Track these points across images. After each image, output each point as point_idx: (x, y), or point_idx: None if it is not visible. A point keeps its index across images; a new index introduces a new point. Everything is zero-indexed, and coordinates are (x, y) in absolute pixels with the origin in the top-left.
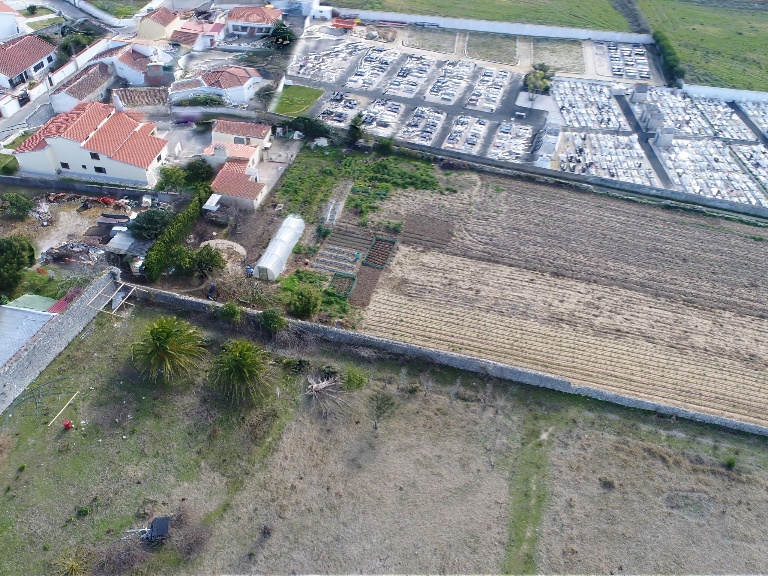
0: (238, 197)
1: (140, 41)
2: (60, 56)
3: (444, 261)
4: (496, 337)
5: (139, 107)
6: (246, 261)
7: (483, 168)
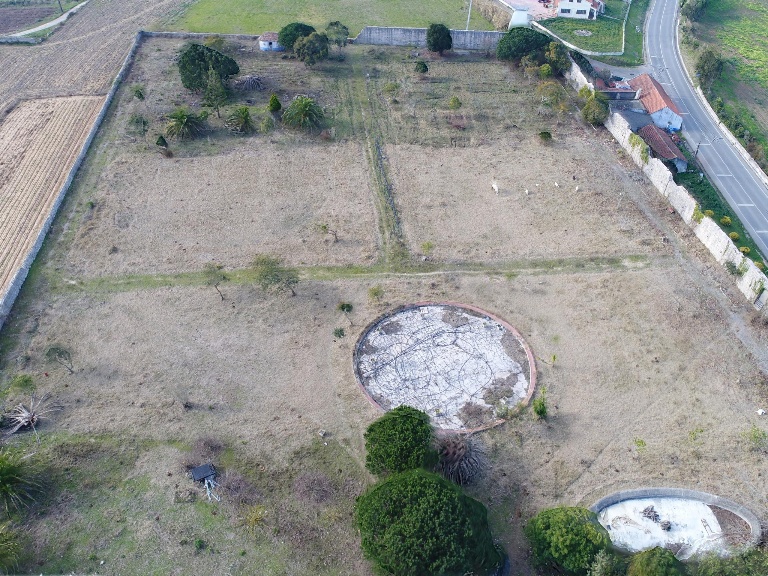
0: None
1: None
2: None
3: None
4: None
5: None
6: None
7: None
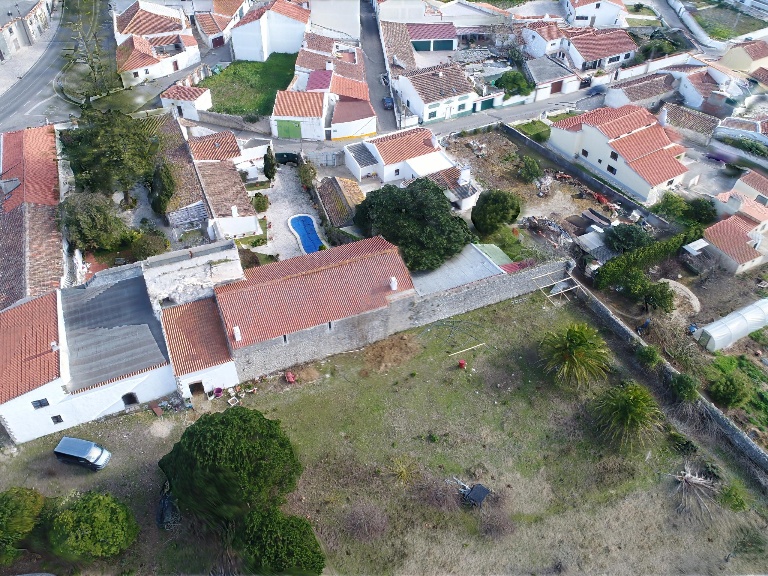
0: (725, 254)
1: (719, 66)
2: (638, 56)
3: None
4: None
5: (681, 128)
6: (695, 318)
7: None
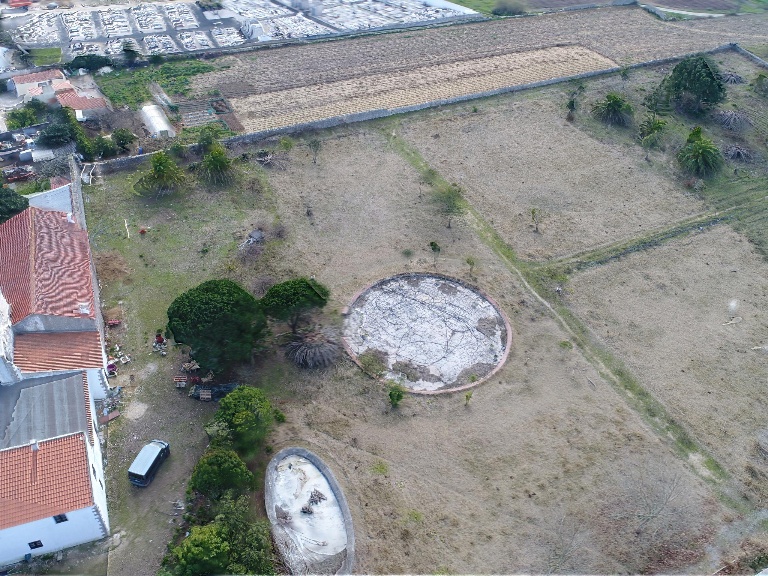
0: (93, 109)
1: None
2: None
3: (263, 97)
4: (329, 114)
5: None
6: None
7: (232, 51)
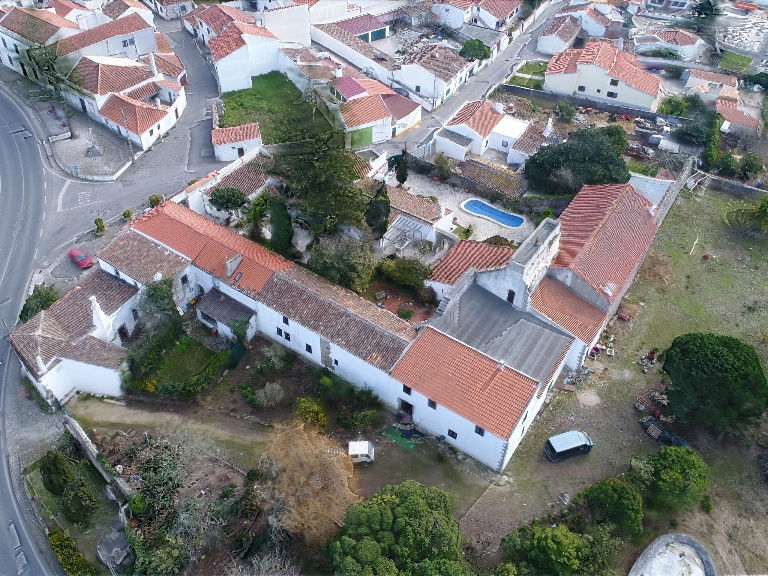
0: (743, 126)
1: None
2: (527, 8)
3: None
4: None
5: None
6: None
7: None
